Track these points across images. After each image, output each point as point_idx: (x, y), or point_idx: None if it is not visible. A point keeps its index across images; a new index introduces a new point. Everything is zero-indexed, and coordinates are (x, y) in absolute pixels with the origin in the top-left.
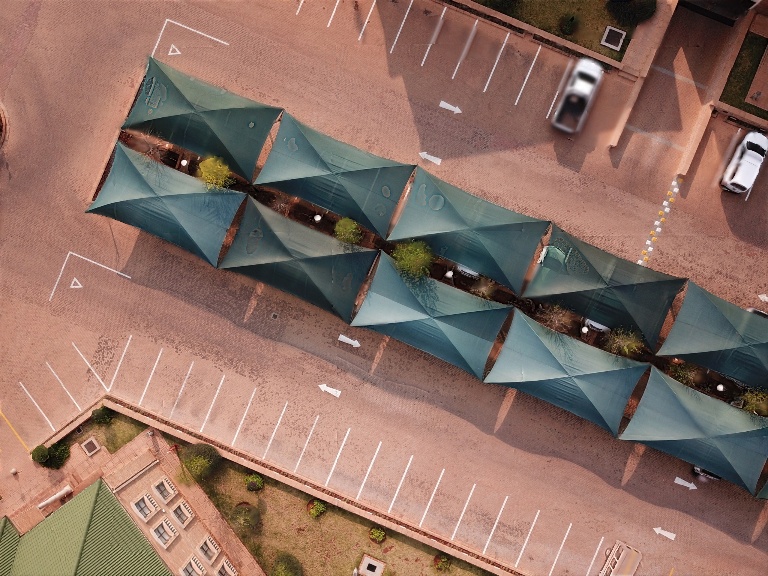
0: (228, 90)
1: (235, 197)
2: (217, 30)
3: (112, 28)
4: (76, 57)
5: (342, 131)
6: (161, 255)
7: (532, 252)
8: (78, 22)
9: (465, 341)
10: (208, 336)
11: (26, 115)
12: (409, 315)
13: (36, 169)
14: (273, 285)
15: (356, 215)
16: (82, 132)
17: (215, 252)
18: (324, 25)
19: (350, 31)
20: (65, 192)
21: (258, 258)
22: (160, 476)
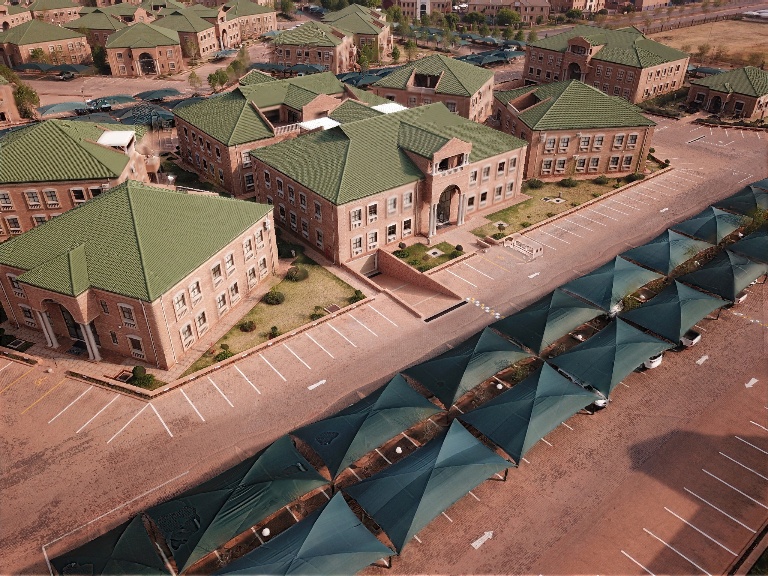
0: None
1: None
2: None
3: None
4: None
5: None
6: None
7: (756, 257)
8: None
9: (698, 223)
10: None
11: None
12: (717, 212)
13: None
14: None
15: None
16: None
17: (757, 186)
18: None
19: None
20: None
21: None
22: (632, 166)
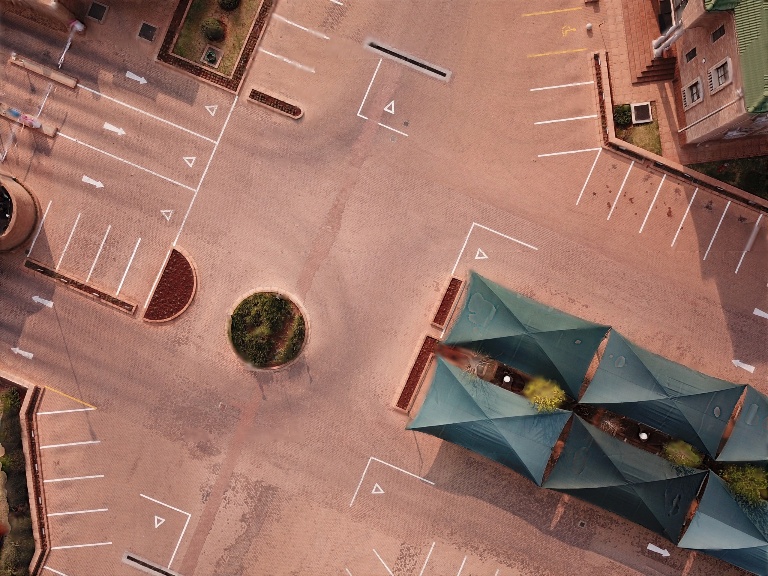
0: (537, 295)
1: (562, 416)
2: (526, 235)
3: (417, 231)
4: (380, 260)
5: (653, 338)
6: (466, 461)
7: None
8: (382, 224)
9: None
10: (513, 544)
11: (328, 318)
12: (746, 541)
13: (338, 373)
14: (600, 506)
15: (689, 437)
16: (386, 336)
17: (540, 471)
18: (636, 231)
19: (663, 237)
20: (367, 396)
21: (591, 482)
22: None
